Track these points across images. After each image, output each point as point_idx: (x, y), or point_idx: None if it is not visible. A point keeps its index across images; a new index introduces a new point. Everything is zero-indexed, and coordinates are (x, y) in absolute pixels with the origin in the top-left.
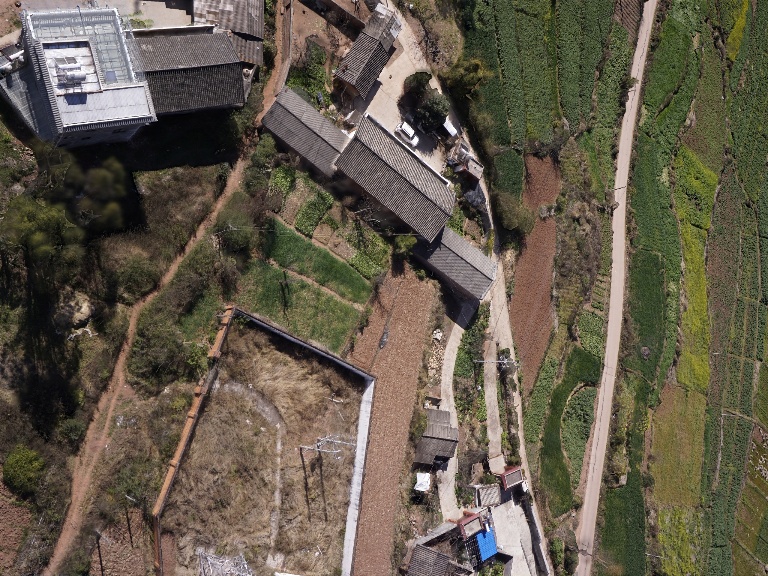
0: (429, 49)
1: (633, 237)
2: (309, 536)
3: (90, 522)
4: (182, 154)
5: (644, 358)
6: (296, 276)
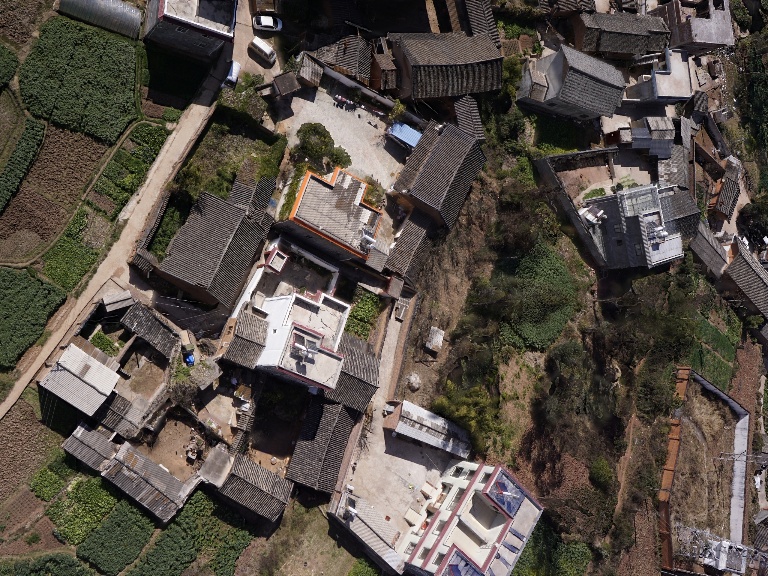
0: (748, 182)
1: None
2: (721, 517)
3: (629, 505)
4: None
5: None
6: (704, 345)
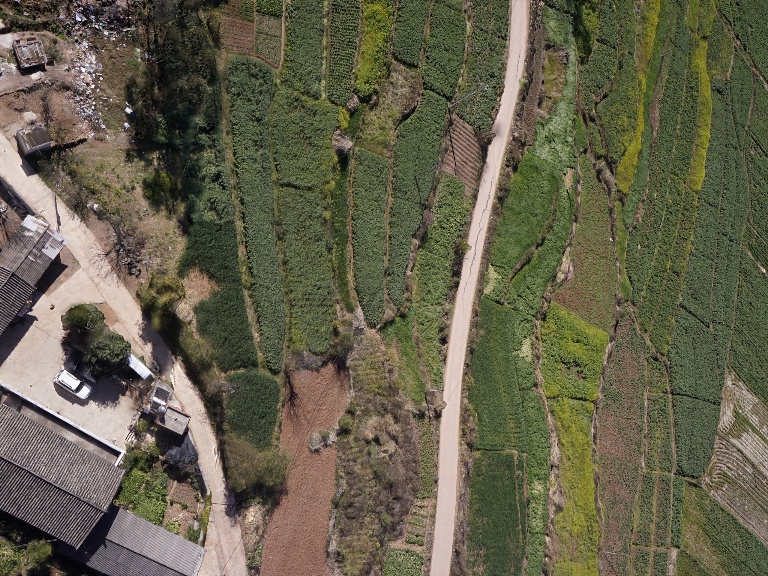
0: (122, 260)
1: (470, 440)
2: None
3: None
4: None
5: None
6: None
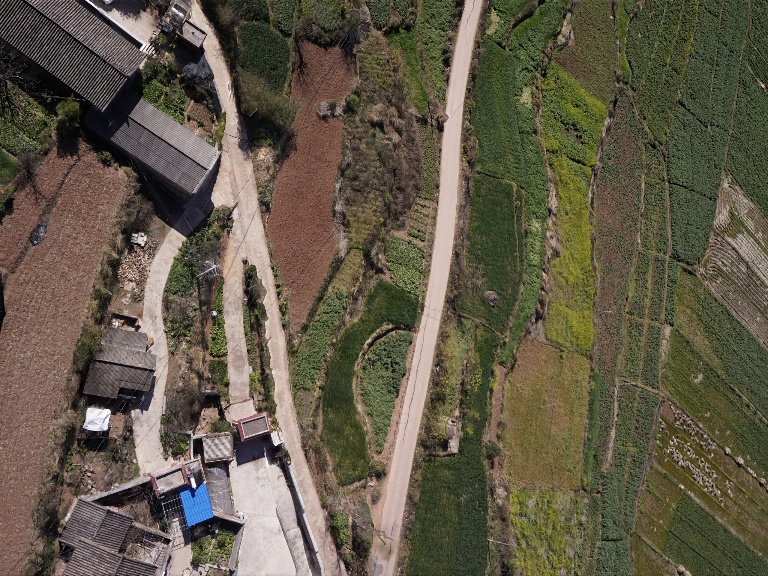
0: None
1: (471, 158)
2: None
3: None
4: None
5: (489, 304)
6: None
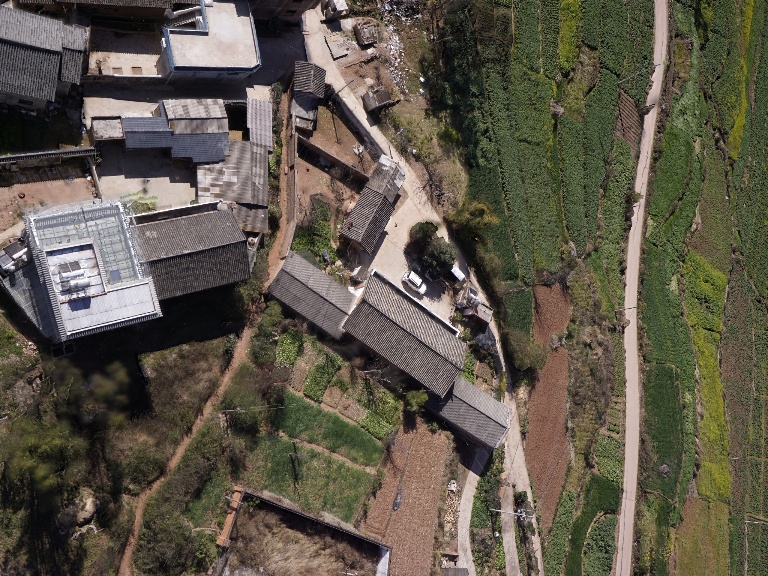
0: (433, 192)
1: (646, 353)
2: None
3: None
4: (188, 330)
5: (663, 476)
6: (306, 445)
